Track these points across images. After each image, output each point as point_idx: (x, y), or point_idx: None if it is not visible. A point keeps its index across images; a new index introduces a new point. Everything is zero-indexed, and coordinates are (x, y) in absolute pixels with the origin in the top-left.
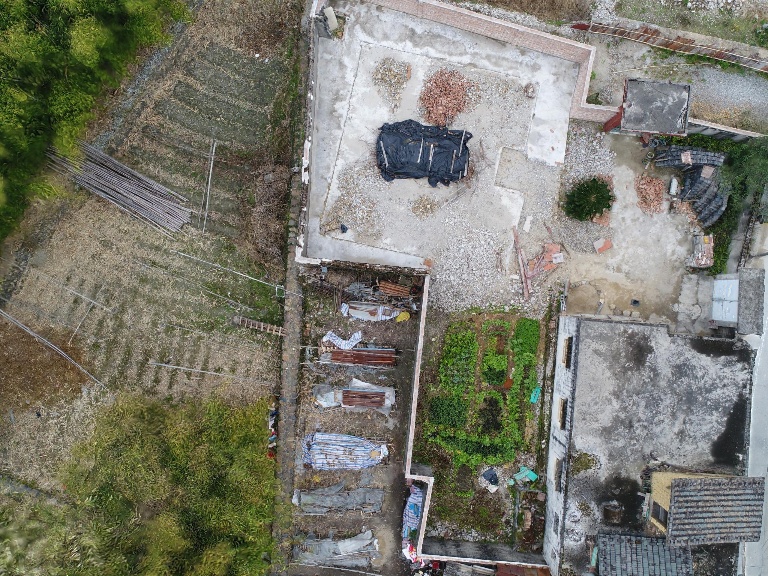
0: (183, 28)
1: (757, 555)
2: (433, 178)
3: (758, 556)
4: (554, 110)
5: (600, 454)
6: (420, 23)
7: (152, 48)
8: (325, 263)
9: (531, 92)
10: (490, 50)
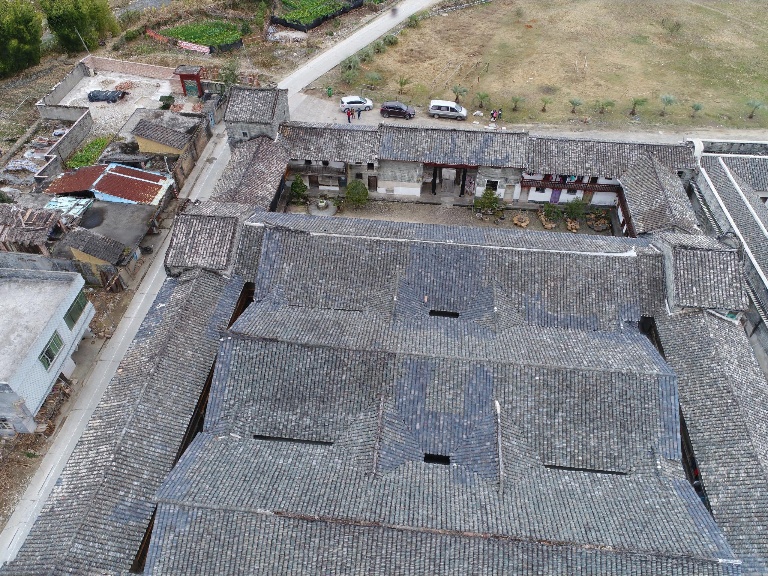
0: (36, 79)
1: (207, 194)
2: (108, 100)
3: (207, 194)
4: (166, 90)
5: (128, 137)
6: (125, 74)
7: (19, 77)
8: (47, 105)
9: (157, 83)
10: (148, 79)
